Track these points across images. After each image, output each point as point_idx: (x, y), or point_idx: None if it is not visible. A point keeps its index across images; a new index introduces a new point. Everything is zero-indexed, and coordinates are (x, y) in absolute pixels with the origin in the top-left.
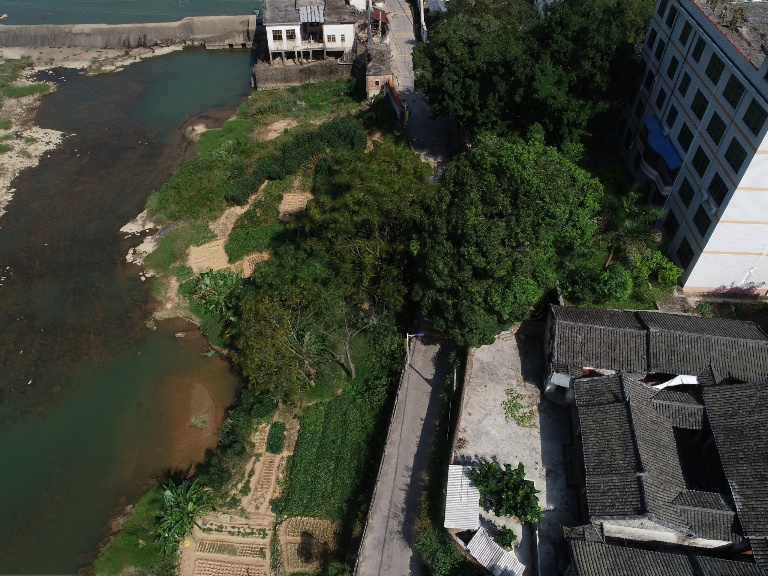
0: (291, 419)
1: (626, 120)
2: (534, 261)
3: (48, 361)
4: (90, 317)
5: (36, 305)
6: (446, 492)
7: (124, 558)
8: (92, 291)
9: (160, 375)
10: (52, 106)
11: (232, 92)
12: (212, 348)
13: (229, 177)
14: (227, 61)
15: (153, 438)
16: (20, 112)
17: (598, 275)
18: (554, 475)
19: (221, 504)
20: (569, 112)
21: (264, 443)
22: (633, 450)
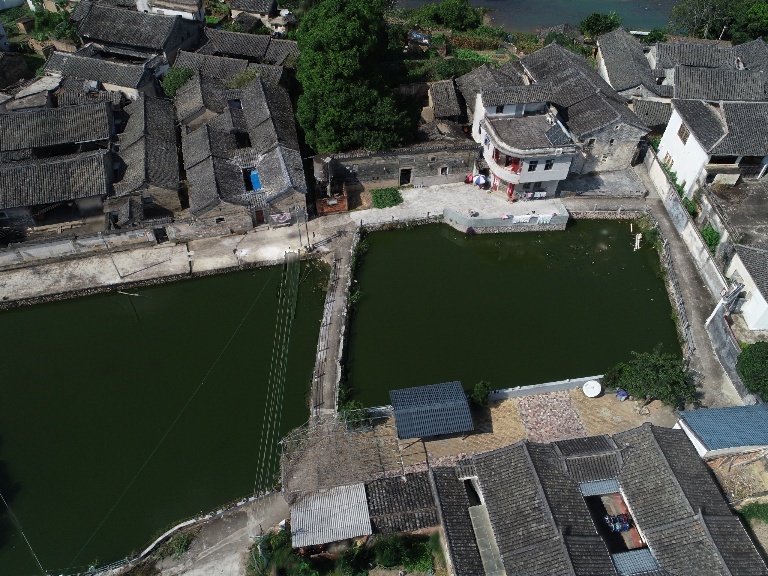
0: None
1: None
2: None
3: (659, 10)
4: None
5: None
6: None
7: None
8: None
9: None
10: None
11: None
12: None
13: None
14: None
15: None
16: None
17: None
18: None
19: None
20: None
21: None
22: None
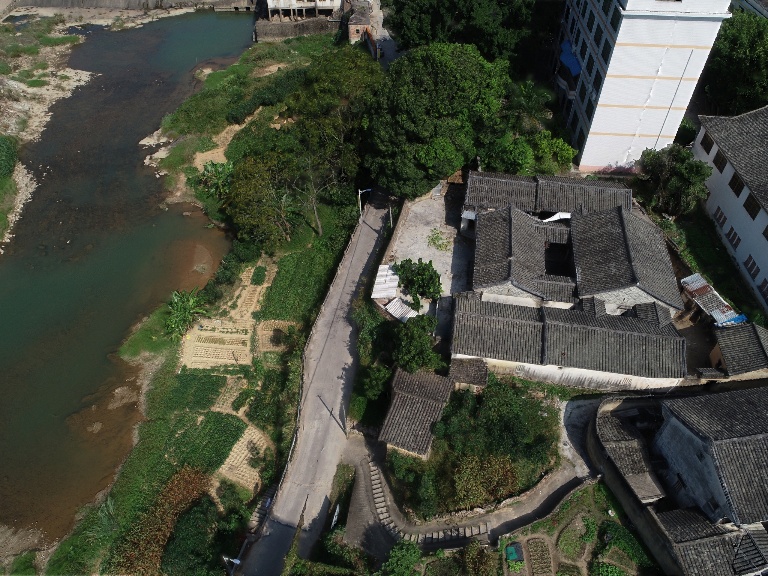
0: (271, 264)
1: (554, 51)
2: (451, 126)
3: (82, 229)
4: (115, 201)
5: (72, 193)
6: (375, 279)
7: (141, 345)
8: (116, 184)
9: (170, 240)
10: (82, 53)
11: (236, 44)
12: (212, 222)
13: (230, 102)
14: (233, 21)
15: (164, 279)
16: (55, 57)
17: (506, 147)
18: (458, 277)
19: (215, 314)
20: (499, 36)
21: (249, 279)
22: (509, 246)
